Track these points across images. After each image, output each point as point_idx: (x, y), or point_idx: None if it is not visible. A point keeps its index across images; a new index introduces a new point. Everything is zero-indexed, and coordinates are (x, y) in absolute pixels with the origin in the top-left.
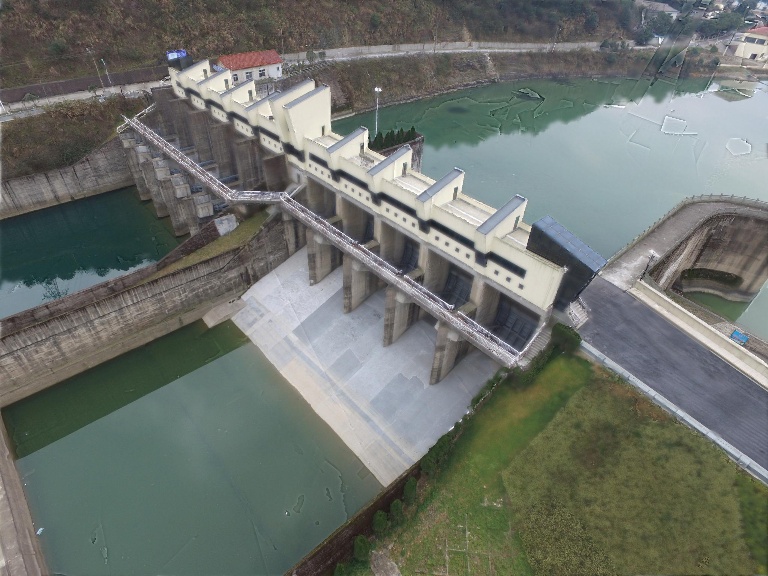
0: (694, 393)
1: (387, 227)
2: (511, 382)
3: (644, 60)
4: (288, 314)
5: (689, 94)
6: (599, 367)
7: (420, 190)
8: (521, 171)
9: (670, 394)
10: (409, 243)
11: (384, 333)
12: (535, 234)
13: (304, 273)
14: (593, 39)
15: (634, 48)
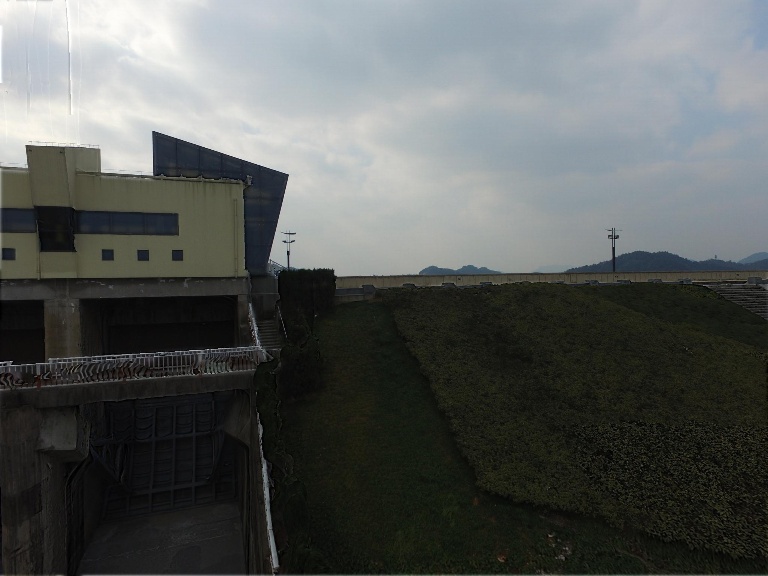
0: None
1: None
2: (285, 399)
3: None
4: None
5: None
6: (378, 292)
7: None
8: None
9: None
10: None
11: None
12: (161, 155)
13: None
14: None
15: None
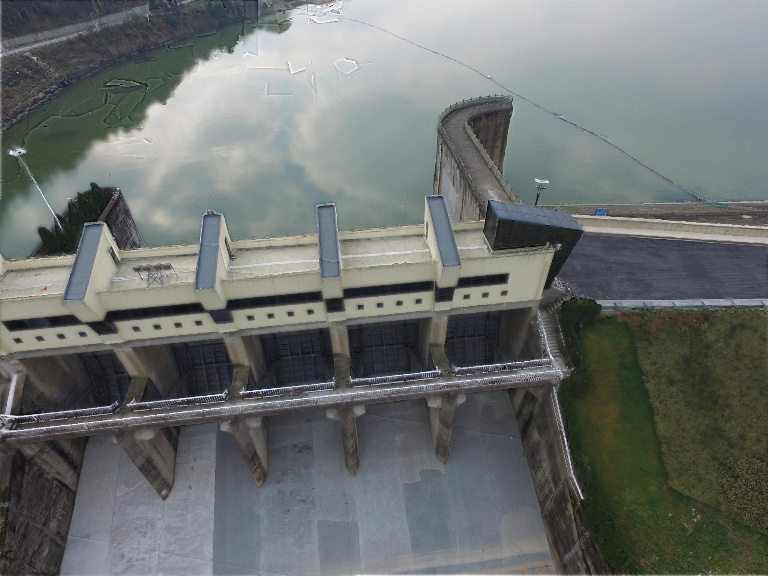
0: (679, 279)
1: (245, 338)
2: None
3: (199, 13)
4: (176, 570)
5: None
6: (627, 315)
7: (284, 262)
8: (222, 171)
9: (676, 293)
10: (263, 334)
11: (352, 463)
12: (500, 229)
13: (132, 492)
14: (132, 4)
15: (182, 3)
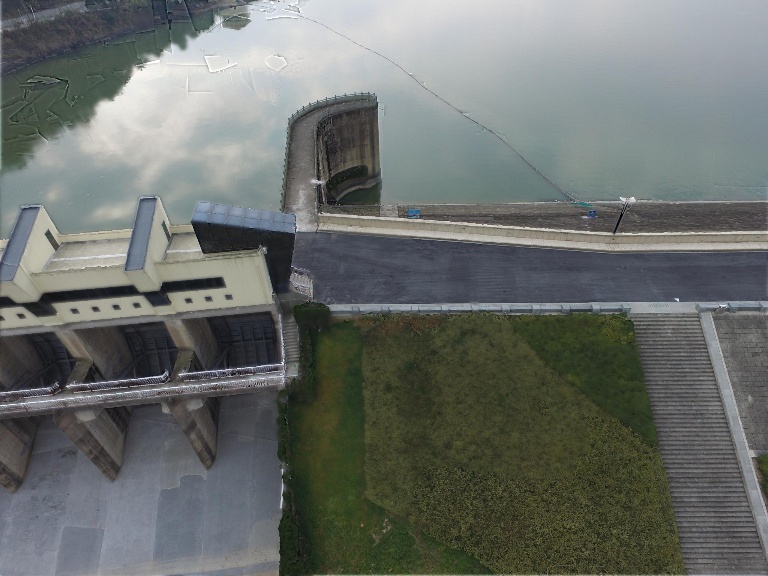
0: (436, 282)
1: None
2: (296, 399)
3: (141, 9)
4: None
5: (203, 31)
6: (361, 319)
7: None
8: (107, 169)
9: (424, 297)
10: (35, 336)
11: (99, 469)
12: (202, 232)
13: None
14: None
15: None
